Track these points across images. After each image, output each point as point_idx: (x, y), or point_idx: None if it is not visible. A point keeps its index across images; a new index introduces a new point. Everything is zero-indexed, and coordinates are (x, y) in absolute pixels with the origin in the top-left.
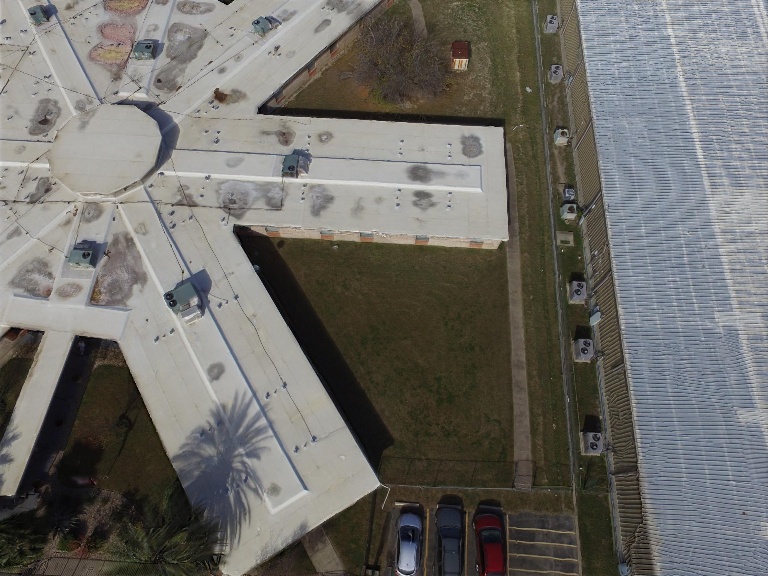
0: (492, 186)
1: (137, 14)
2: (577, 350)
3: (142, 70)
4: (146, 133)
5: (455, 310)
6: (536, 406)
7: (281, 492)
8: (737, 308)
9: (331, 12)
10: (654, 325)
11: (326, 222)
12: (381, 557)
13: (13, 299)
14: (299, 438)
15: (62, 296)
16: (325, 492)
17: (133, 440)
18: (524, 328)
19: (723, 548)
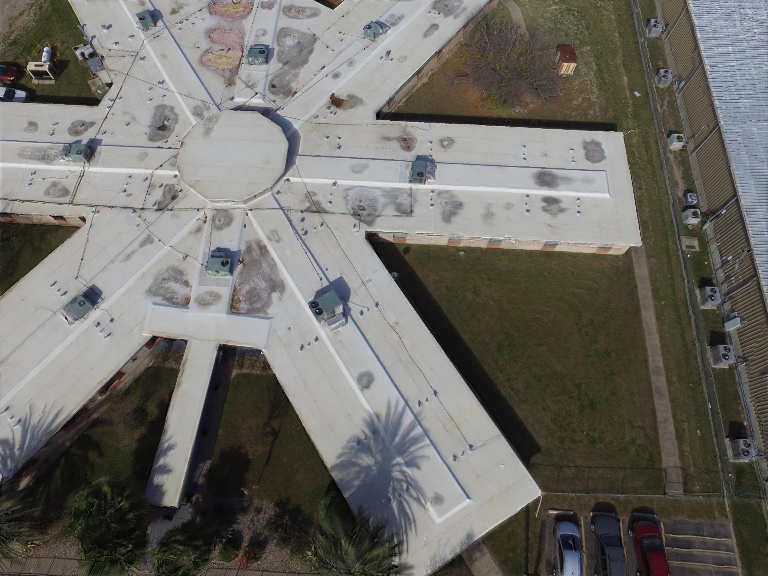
0: (619, 191)
1: (243, 19)
2: (716, 356)
3: (256, 75)
4: (272, 139)
5: (587, 316)
6: (679, 412)
7: (445, 501)
8: None
9: (438, 16)
10: None
11: (458, 228)
12: (540, 565)
13: (153, 307)
14: (456, 446)
15: (202, 304)
16: (488, 501)
17: (279, 449)
18: (658, 334)
19: None
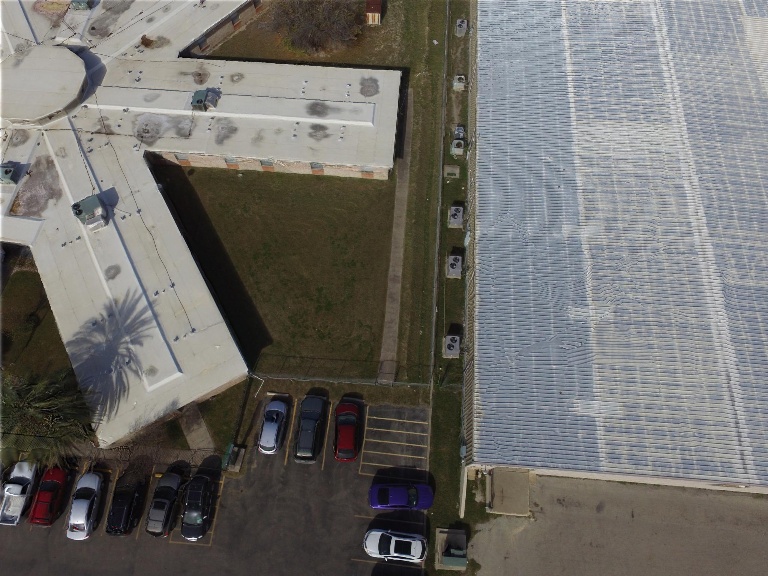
0: (383, 121)
1: None
2: None
3: (79, 19)
4: (72, 70)
5: (343, 231)
6: (406, 314)
7: (158, 373)
8: (583, 222)
9: None
10: None
11: (228, 149)
12: (249, 438)
13: None
14: (180, 330)
15: None
16: (198, 375)
17: (40, 334)
18: (404, 248)
19: (545, 427)
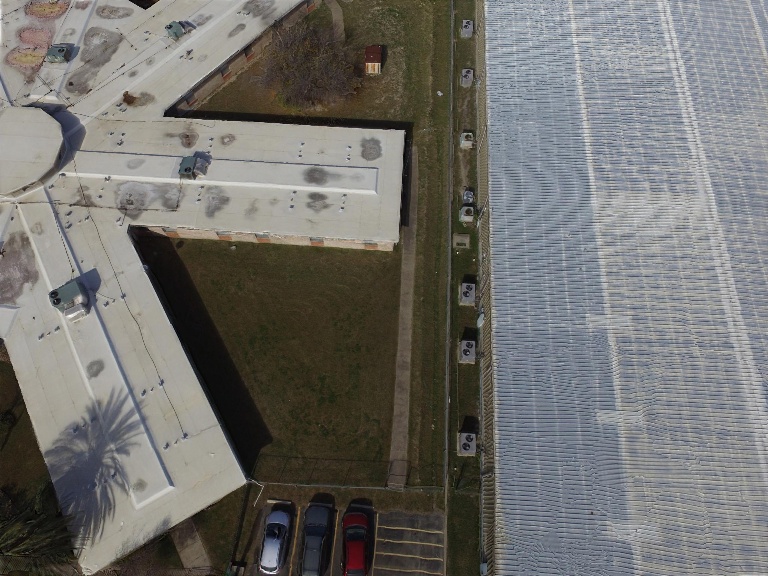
0: (387, 188)
1: (56, 18)
2: (461, 351)
3: (55, 73)
4: (48, 135)
5: (345, 311)
6: (416, 406)
7: (147, 488)
8: (609, 311)
9: (246, 17)
10: (525, 327)
11: (219, 223)
12: (248, 554)
13: None
14: (171, 435)
15: None
16: (191, 488)
17: (16, 435)
18: (412, 329)
19: None
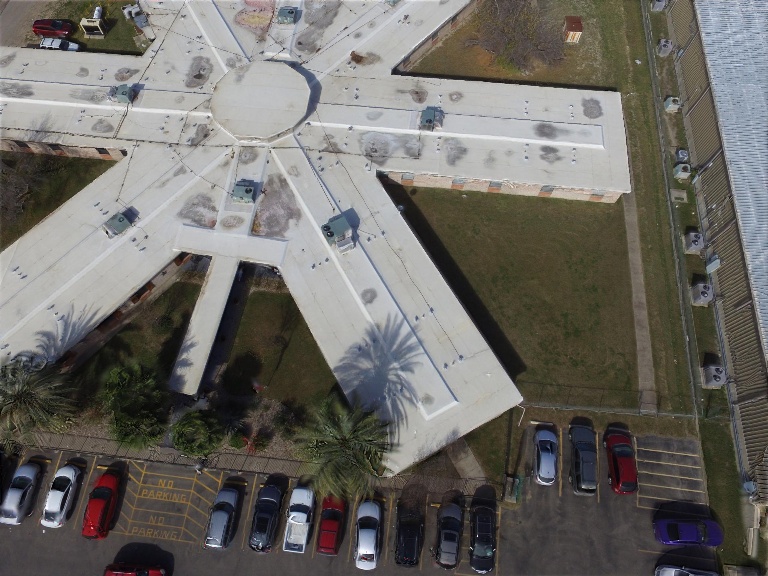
0: (613, 144)
1: None
2: (696, 294)
3: (284, 33)
4: (296, 86)
5: (578, 256)
6: (658, 343)
7: (435, 401)
8: None
9: None
10: None
11: (461, 171)
12: (520, 468)
13: (183, 227)
14: (447, 356)
15: (226, 226)
16: (474, 404)
17: (289, 356)
18: (643, 274)
19: None
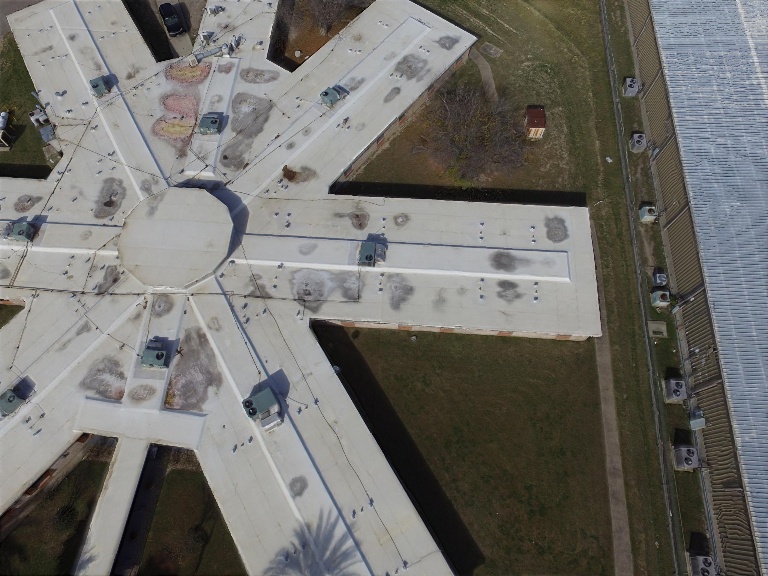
0: (581, 275)
1: (199, 84)
2: (679, 459)
3: (207, 146)
4: (217, 220)
5: (543, 410)
6: (637, 522)
7: None
8: None
9: (400, 79)
10: None
11: (406, 316)
12: None
13: (85, 402)
14: (390, 563)
15: (135, 399)
16: None
17: (210, 554)
18: (619, 431)
19: None
